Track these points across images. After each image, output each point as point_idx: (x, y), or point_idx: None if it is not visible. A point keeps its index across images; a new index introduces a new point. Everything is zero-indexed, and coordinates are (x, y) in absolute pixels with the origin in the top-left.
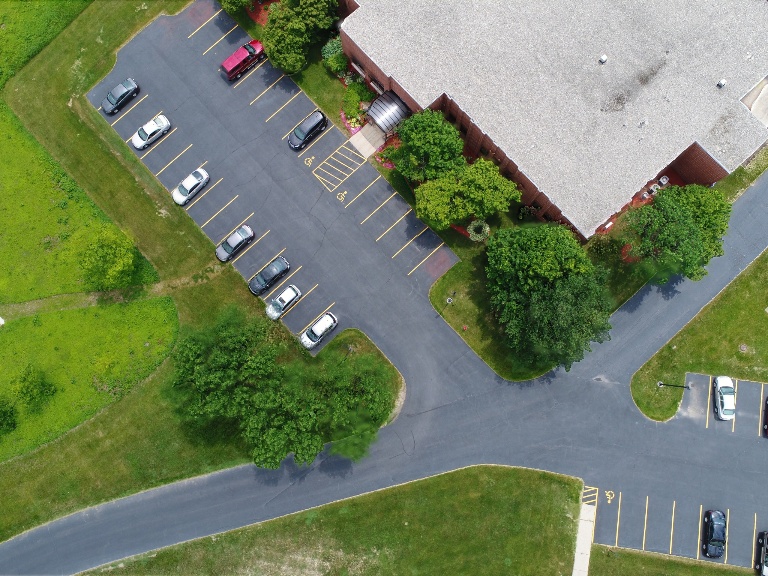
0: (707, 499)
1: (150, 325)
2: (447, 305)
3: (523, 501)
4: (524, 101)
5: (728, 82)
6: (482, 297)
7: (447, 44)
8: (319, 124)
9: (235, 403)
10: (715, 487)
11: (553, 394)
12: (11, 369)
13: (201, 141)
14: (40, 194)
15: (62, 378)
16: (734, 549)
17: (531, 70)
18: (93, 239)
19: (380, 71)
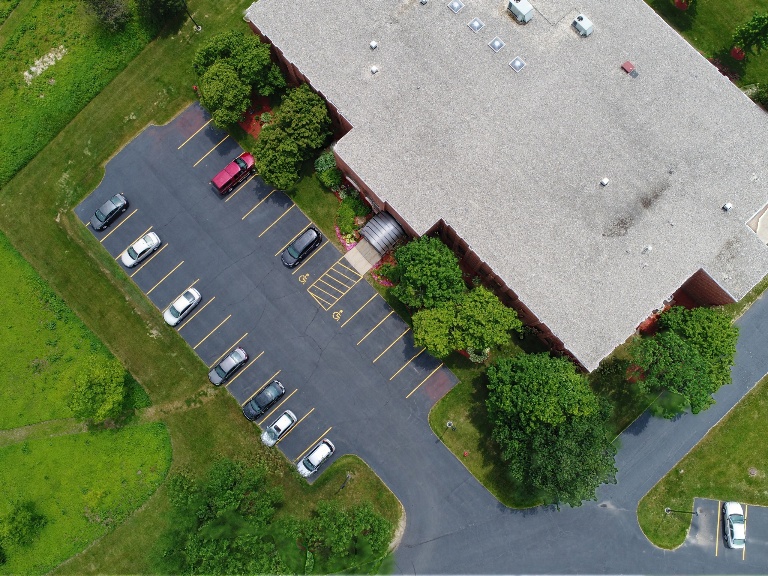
0: None
1: (142, 452)
2: (447, 429)
3: None
4: (524, 227)
5: (734, 205)
6: (483, 420)
7: (443, 167)
8: (313, 242)
9: (228, 572)
10: None
11: (557, 522)
12: (0, 499)
13: (192, 258)
14: (28, 315)
15: (52, 509)
16: None
17: (530, 194)
18: (83, 362)
19: (375, 195)
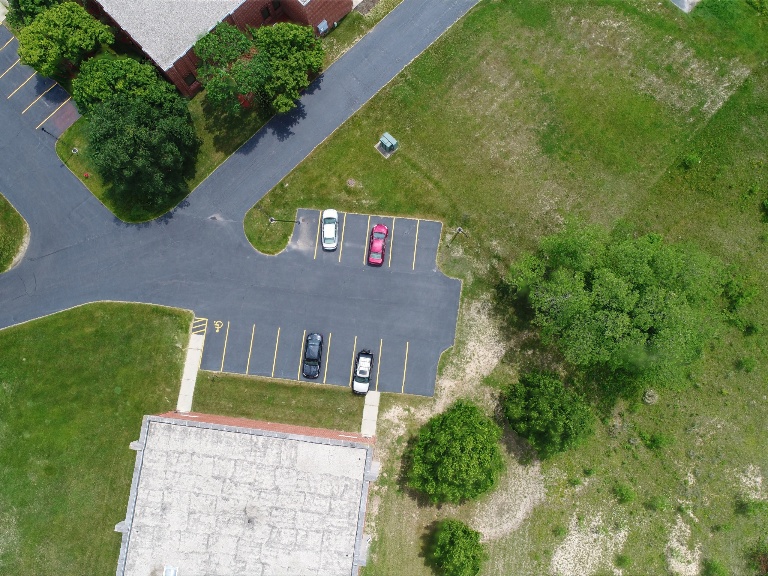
0: (311, 325)
1: None
2: (72, 155)
3: (135, 333)
4: None
5: None
6: None
7: None
8: None
9: None
10: (319, 313)
11: (169, 233)
12: None
13: None
14: None
15: None
16: (334, 370)
17: None
18: None
19: None
